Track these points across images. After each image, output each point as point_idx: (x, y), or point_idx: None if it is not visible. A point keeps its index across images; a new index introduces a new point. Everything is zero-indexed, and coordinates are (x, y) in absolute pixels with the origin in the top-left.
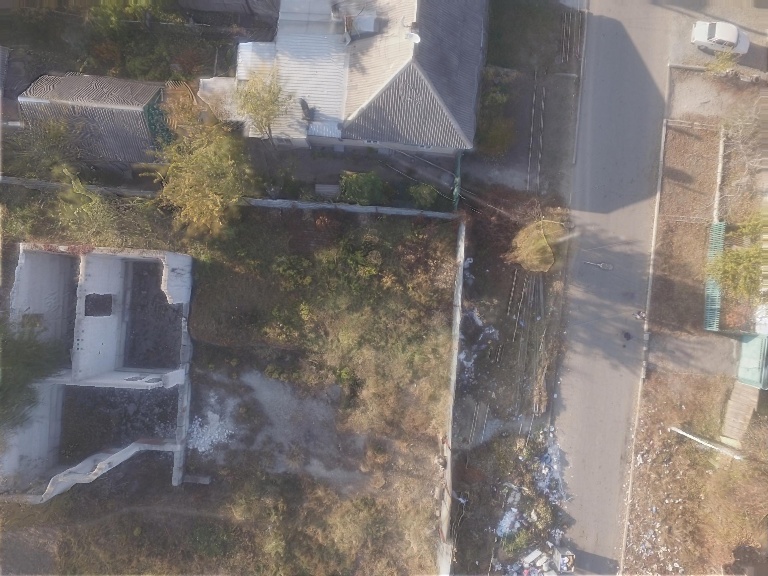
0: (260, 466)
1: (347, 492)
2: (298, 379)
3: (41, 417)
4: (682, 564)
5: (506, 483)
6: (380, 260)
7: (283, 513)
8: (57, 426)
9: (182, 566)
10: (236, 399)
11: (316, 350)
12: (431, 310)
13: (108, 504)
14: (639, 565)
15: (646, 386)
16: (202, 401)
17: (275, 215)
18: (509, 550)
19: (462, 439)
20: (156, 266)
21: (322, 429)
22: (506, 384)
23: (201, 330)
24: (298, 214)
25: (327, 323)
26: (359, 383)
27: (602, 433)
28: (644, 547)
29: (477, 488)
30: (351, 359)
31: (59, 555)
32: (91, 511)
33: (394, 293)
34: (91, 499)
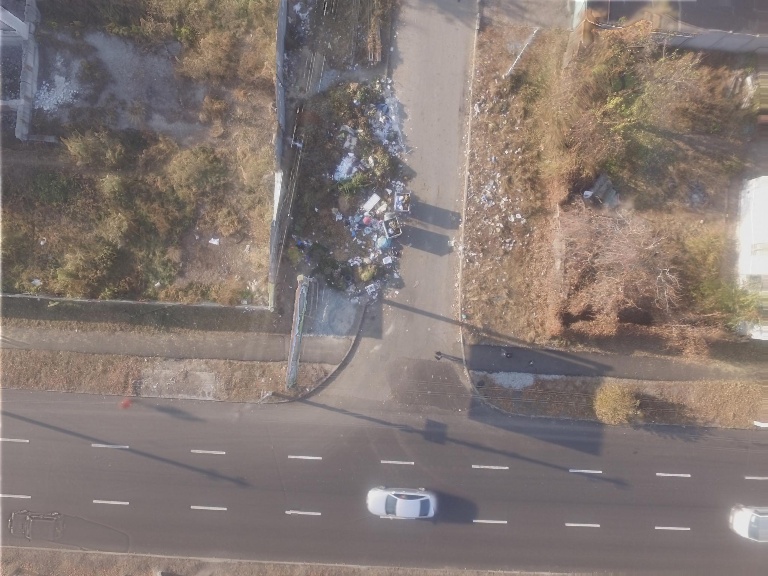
0: (103, 122)
1: (187, 143)
2: (138, 34)
3: None
4: (523, 213)
5: (341, 127)
6: None
7: (120, 154)
8: None
9: (24, 214)
10: (81, 60)
11: (155, 4)
12: None
13: None
14: (481, 216)
15: (481, 38)
16: (50, 67)
17: None
18: (345, 190)
19: (299, 88)
20: None
21: (163, 85)
22: (341, 34)
23: None
24: None
25: None
26: (198, 37)
27: (440, 86)
28: (484, 196)
29: (312, 130)
30: (189, 13)
31: None
32: None
33: None
34: None
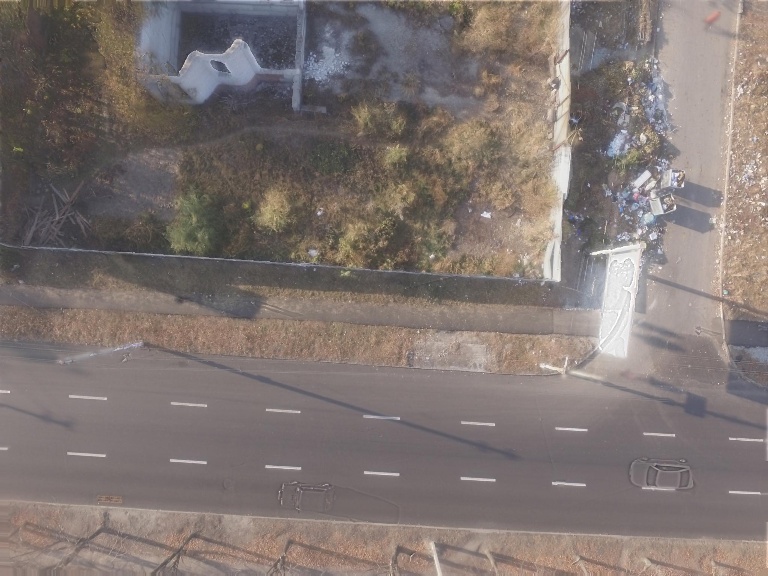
0: (376, 94)
1: (462, 117)
2: (413, 8)
3: (165, 34)
4: None
5: (616, 104)
6: None
7: None
8: (175, 61)
9: (303, 183)
10: (351, 32)
11: None
12: None
13: (230, 120)
14: (742, 194)
15: (743, 21)
16: (317, 38)
17: None
18: (621, 166)
19: (572, 65)
20: None
21: (436, 59)
22: (612, 14)
23: None
24: None
25: None
26: (472, 12)
27: (703, 67)
28: (747, 175)
29: (589, 106)
30: None
31: (181, 173)
32: (213, 130)
33: None
34: (213, 116)
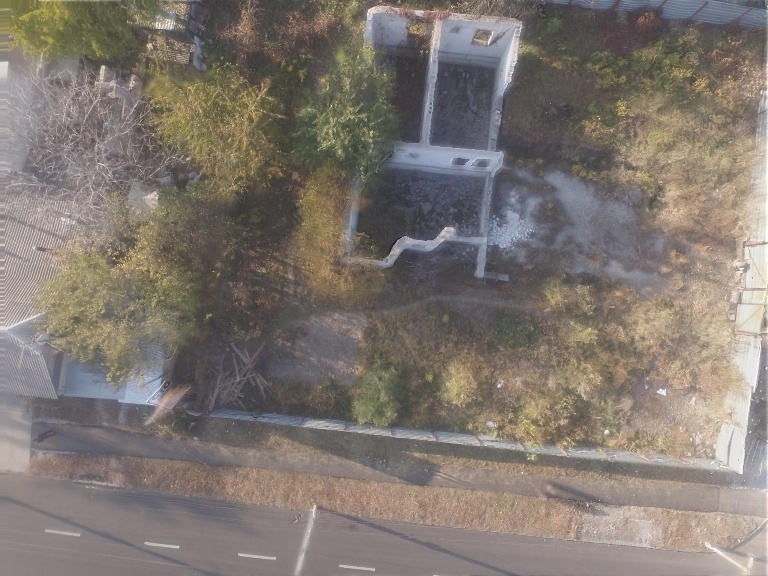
0: (560, 264)
1: (645, 293)
2: (603, 179)
3: None
4: None
5: None
6: (697, 61)
7: None
8: (357, 218)
9: (486, 356)
10: (537, 199)
11: (624, 151)
12: (736, 118)
13: (418, 290)
14: None
15: None
16: (500, 201)
17: (589, 16)
18: None
19: None
20: (457, 68)
21: (622, 231)
22: None
23: (515, 123)
24: (612, 16)
25: (639, 122)
26: (661, 187)
27: None
28: None
29: None
30: (656, 162)
31: (365, 340)
32: (398, 297)
33: (703, 98)
34: (401, 284)
